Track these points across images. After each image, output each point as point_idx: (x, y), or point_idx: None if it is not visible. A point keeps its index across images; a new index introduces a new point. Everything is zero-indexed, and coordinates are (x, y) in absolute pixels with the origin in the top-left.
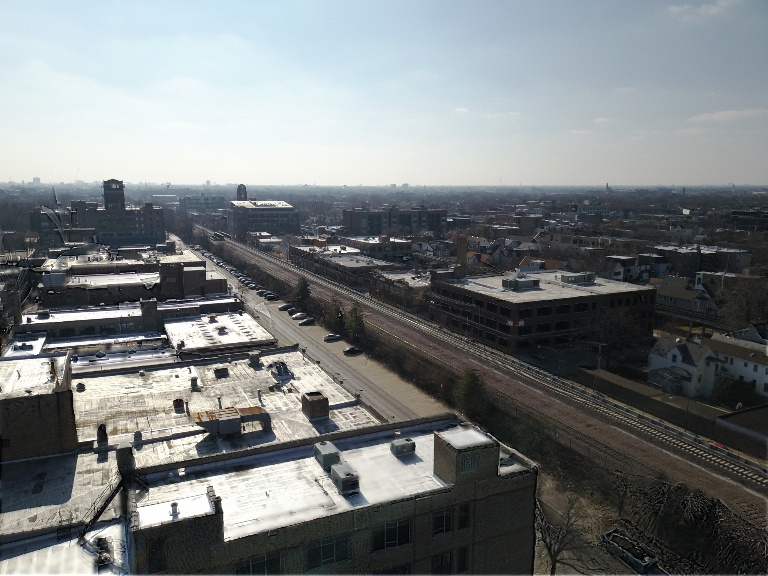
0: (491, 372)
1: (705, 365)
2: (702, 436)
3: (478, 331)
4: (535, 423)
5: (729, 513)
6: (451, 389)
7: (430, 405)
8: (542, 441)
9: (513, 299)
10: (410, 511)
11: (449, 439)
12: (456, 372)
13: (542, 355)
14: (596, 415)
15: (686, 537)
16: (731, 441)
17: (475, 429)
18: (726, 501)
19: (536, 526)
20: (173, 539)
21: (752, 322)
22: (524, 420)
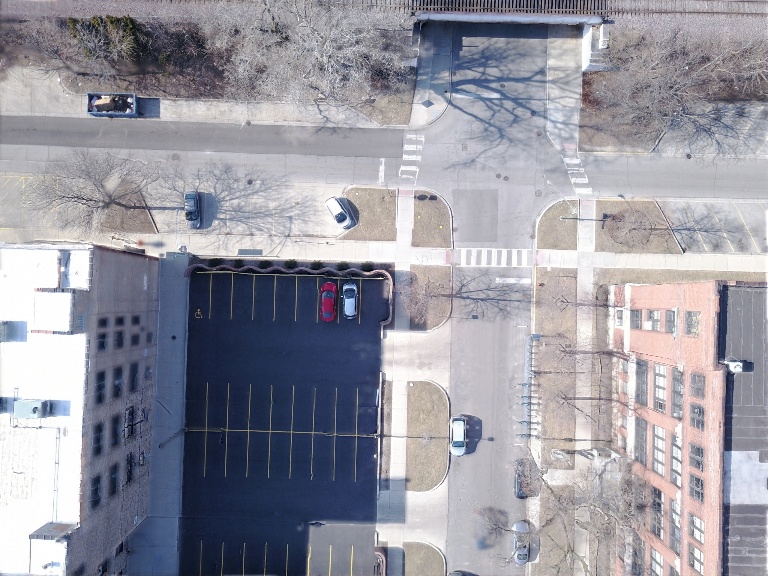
0: None
1: None
2: None
3: None
4: None
5: (149, 33)
6: None
7: None
8: None
9: None
10: (93, 377)
11: (45, 325)
12: None
13: None
14: None
15: None
16: None
17: (39, 292)
18: (132, 10)
19: None
20: (73, 567)
21: None
22: None
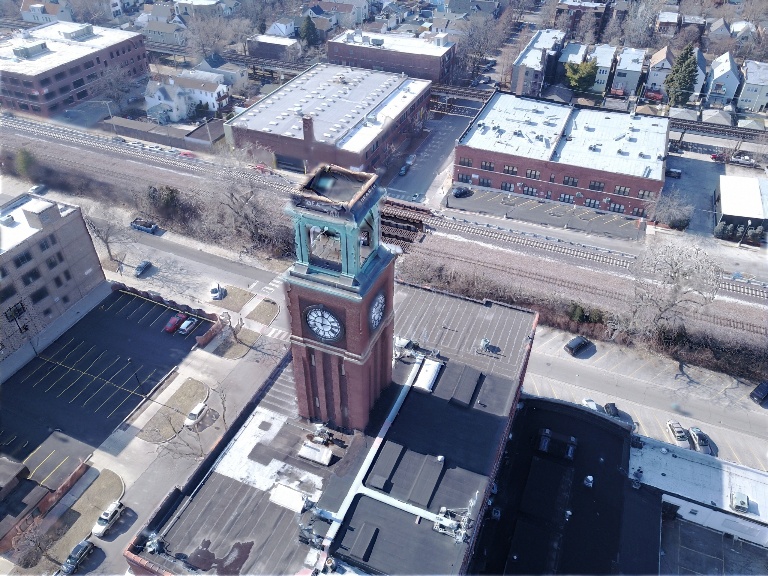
0: (37, 142)
1: (178, 99)
2: (176, 151)
3: (11, 103)
4: (80, 173)
5: (179, 193)
6: (12, 166)
7: (1, 181)
8: (88, 183)
9: (31, 71)
10: (27, 246)
11: (31, 210)
12: (10, 150)
13: (71, 117)
14: (117, 155)
15: (166, 210)
16: (188, 151)
17: (42, 200)
18: (179, 187)
19: (92, 231)
20: None
21: (204, 56)
22: (72, 173)
